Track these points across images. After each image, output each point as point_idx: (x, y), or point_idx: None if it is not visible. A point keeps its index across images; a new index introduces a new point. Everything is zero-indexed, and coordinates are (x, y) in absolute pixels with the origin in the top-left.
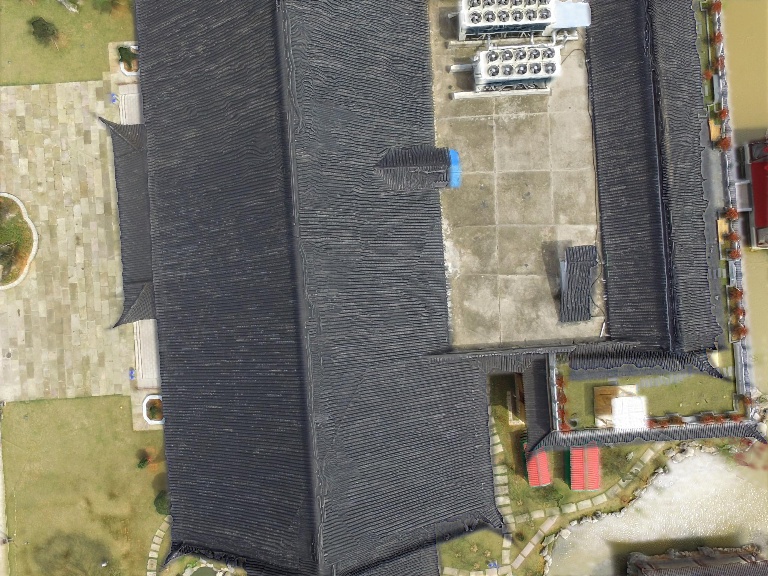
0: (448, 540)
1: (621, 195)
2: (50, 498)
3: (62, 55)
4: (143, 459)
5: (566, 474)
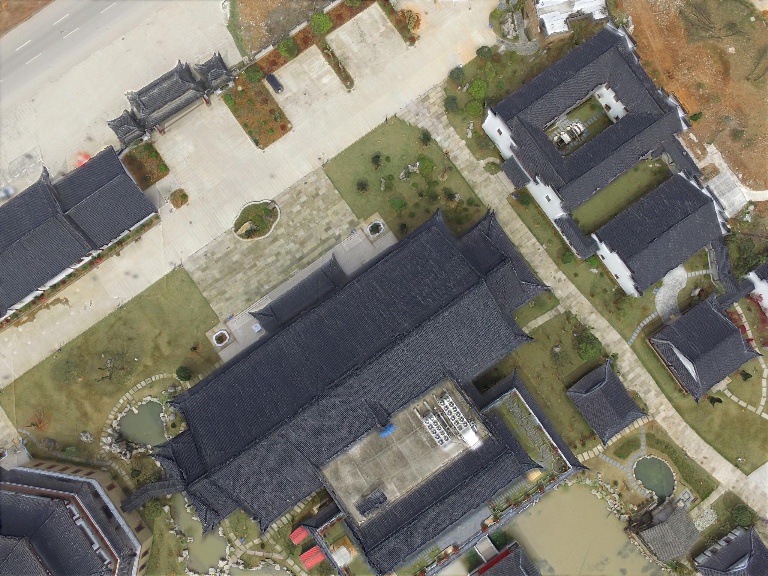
0: (241, 512)
1: (415, 497)
2: (152, 315)
3: (358, 195)
4: (195, 348)
5: (306, 550)
